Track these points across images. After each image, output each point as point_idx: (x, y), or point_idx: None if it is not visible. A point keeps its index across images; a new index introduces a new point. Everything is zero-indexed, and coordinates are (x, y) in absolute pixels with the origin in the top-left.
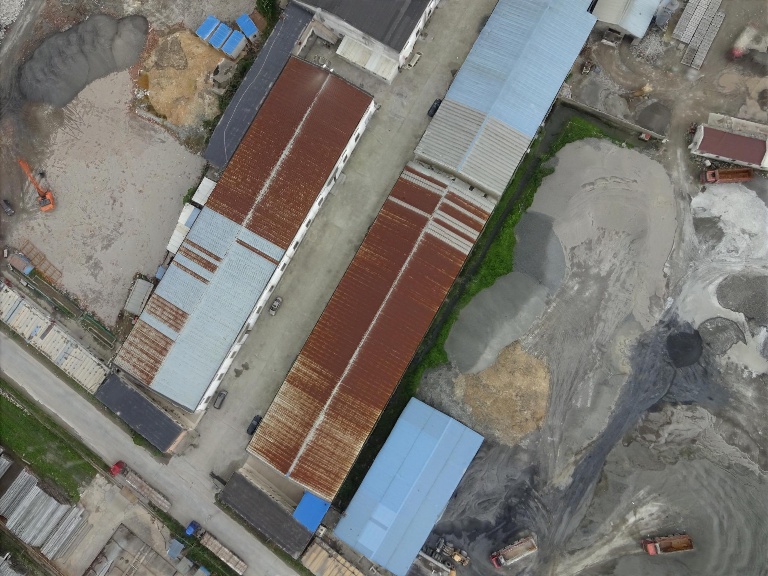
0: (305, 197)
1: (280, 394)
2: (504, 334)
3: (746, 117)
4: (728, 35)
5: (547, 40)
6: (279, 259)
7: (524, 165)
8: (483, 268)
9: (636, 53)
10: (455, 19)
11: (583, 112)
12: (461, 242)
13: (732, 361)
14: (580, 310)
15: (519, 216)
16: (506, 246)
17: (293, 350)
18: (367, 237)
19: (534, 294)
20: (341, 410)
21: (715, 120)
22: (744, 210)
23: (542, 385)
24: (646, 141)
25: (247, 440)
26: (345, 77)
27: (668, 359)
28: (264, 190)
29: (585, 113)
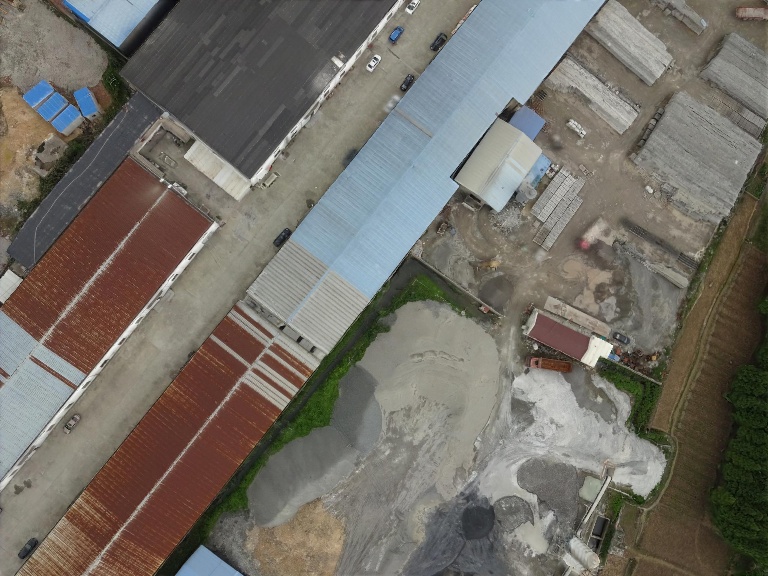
0: (118, 320)
1: (56, 530)
2: (307, 492)
3: (580, 306)
4: (582, 221)
5: (404, 200)
6: (78, 383)
7: (362, 316)
8: (301, 417)
9: (493, 221)
10: (321, 144)
11: (431, 270)
12: (278, 396)
13: (517, 539)
14: (387, 476)
15: (347, 369)
16: (328, 398)
17: (84, 473)
18: (180, 375)
19: (343, 458)
20: (120, 556)
21: (552, 304)
22: (557, 401)
23: (335, 547)
24: (484, 313)
25: (17, 563)
26: (191, 183)
27: (461, 530)
28: (71, 306)
29: (433, 272)
